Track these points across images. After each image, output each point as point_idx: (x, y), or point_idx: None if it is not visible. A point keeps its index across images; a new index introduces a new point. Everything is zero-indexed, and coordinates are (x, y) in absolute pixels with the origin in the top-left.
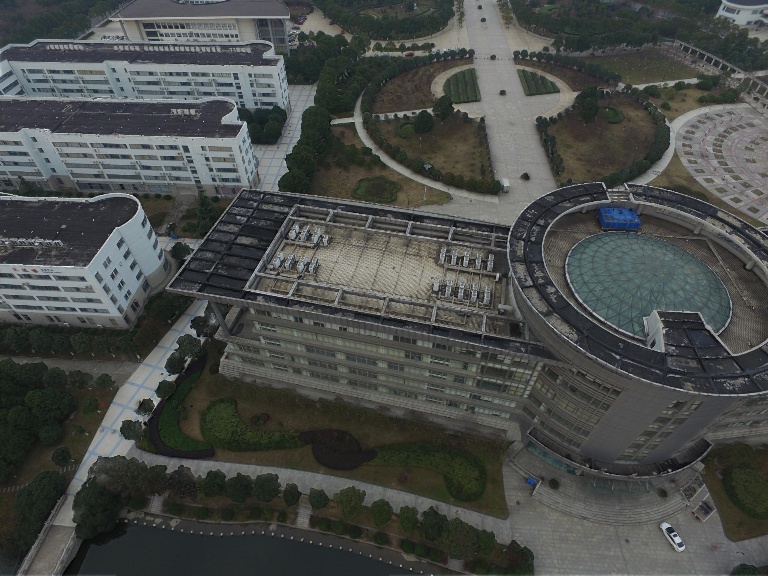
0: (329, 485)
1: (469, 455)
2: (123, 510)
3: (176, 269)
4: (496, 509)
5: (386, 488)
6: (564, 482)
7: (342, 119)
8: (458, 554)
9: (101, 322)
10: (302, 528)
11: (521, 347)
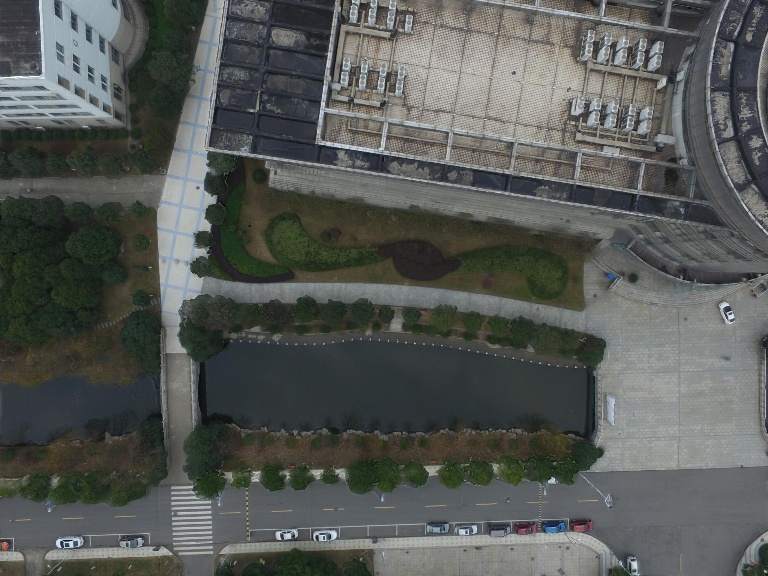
0: (416, 295)
1: (553, 256)
2: (224, 332)
3: (141, 13)
4: (574, 303)
5: (471, 293)
6: (643, 275)
7: None
8: (545, 354)
9: (86, 123)
10: (395, 332)
11: (681, 207)
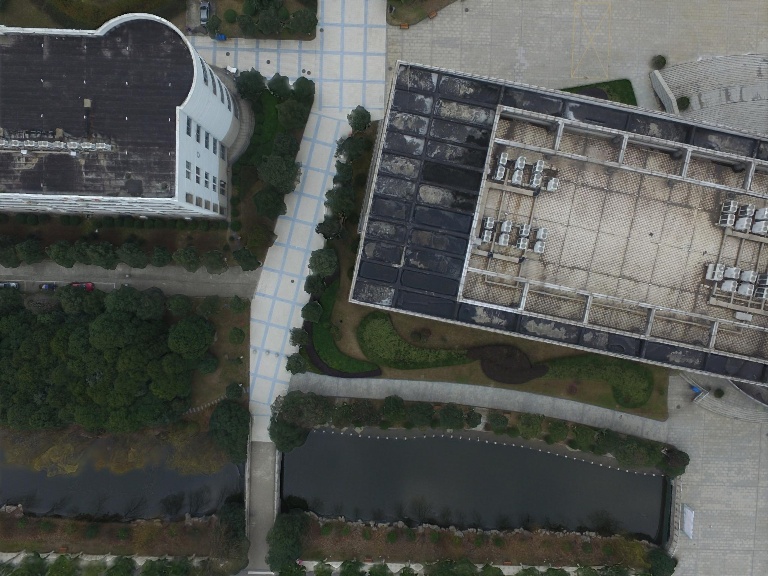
0: (501, 398)
1: (641, 367)
2: None
3: (248, 108)
4: (657, 414)
5: (555, 398)
6: (728, 390)
7: None
8: None
9: (189, 215)
10: (477, 430)
11: None
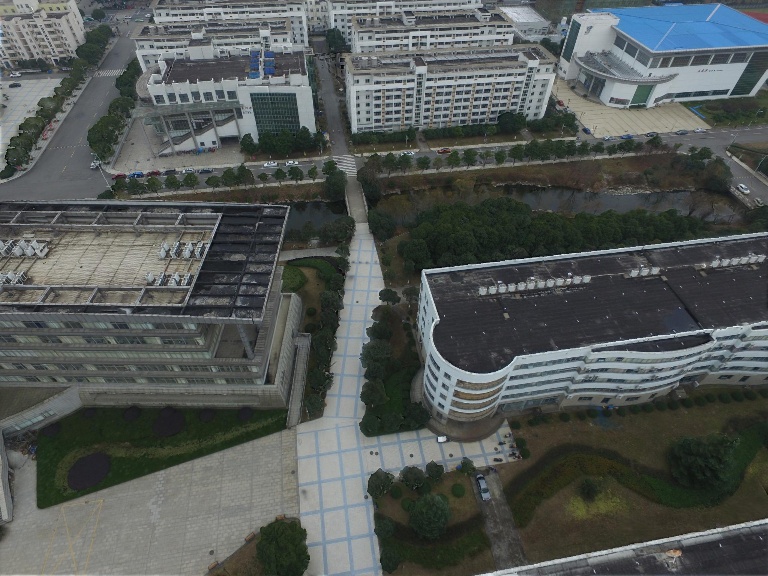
0: None
1: None
2: None
3: None
4: None
5: None
6: None
7: None
8: None
9: None
10: None
11: None
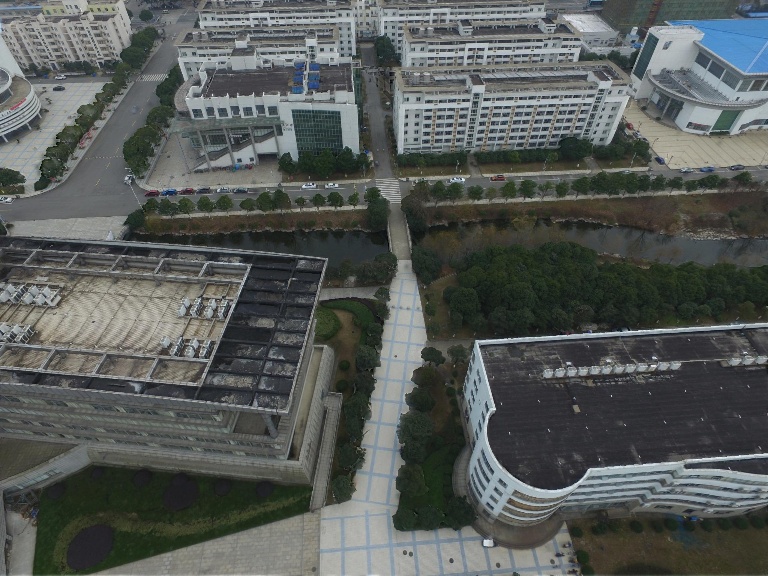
0: None
1: None
2: None
3: None
4: None
5: None
6: None
7: None
8: None
9: None
10: None
11: None
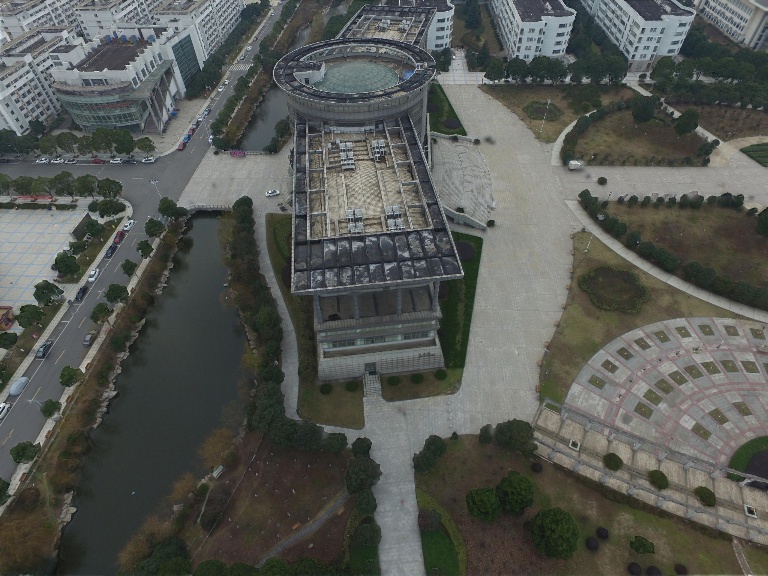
0: None
1: None
2: None
3: None
4: None
5: None
6: None
7: (649, 93)
8: None
9: None
10: None
11: None
